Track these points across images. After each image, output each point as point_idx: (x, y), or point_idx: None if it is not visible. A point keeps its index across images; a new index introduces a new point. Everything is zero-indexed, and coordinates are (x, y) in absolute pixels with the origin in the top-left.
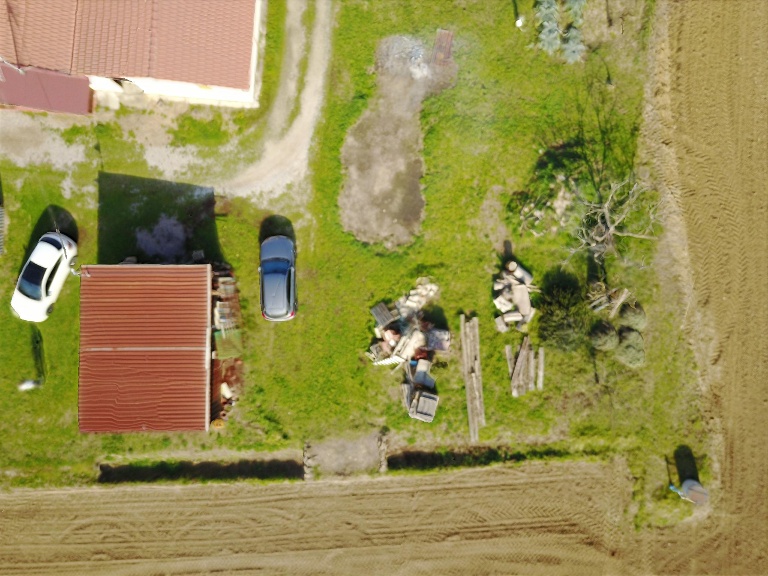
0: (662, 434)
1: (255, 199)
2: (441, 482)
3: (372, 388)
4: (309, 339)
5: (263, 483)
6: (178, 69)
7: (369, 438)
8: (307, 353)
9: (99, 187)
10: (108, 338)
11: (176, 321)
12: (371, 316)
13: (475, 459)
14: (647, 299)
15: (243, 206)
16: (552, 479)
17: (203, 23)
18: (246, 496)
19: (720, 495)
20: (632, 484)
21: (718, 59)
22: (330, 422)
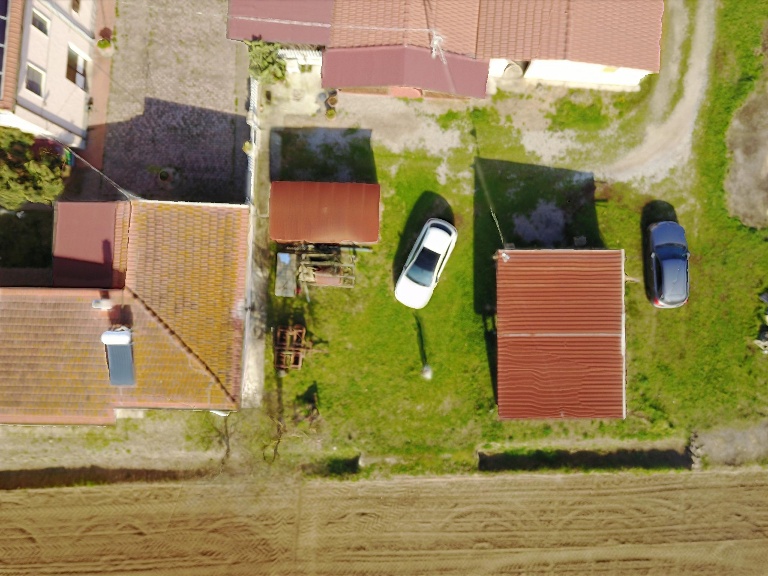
0: None
1: (636, 184)
2: None
3: (761, 377)
4: (694, 327)
5: (648, 473)
6: (592, 51)
7: (759, 428)
8: (692, 341)
9: (475, 173)
10: (526, 324)
11: (592, 307)
12: (762, 303)
13: None
14: None
15: (623, 191)
16: None
17: (616, 4)
18: (629, 486)
19: None
20: None
21: None
22: (717, 411)
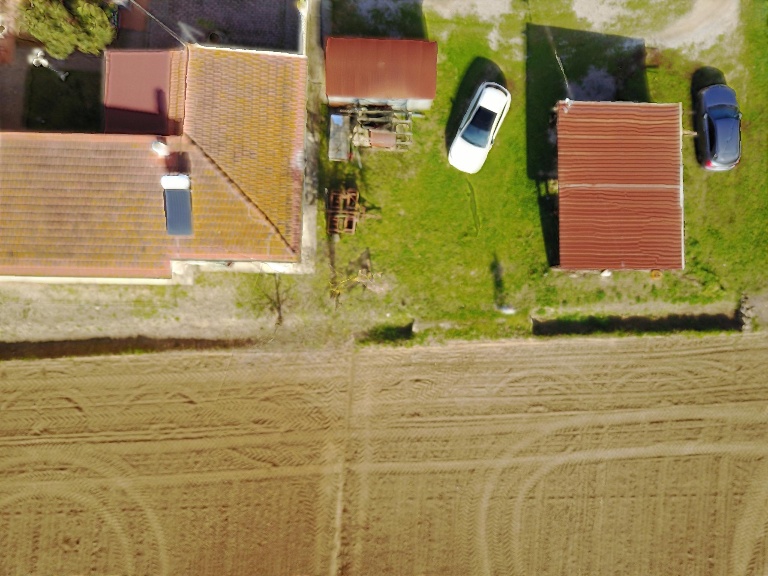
0: None
1: (686, 50)
2: None
3: None
4: (744, 190)
5: (699, 335)
6: None
7: None
8: (741, 205)
9: (527, 39)
10: (587, 174)
11: (651, 158)
12: None
13: None
14: None
15: (674, 58)
16: None
17: None
18: (680, 349)
19: None
20: None
21: None
22: (766, 274)
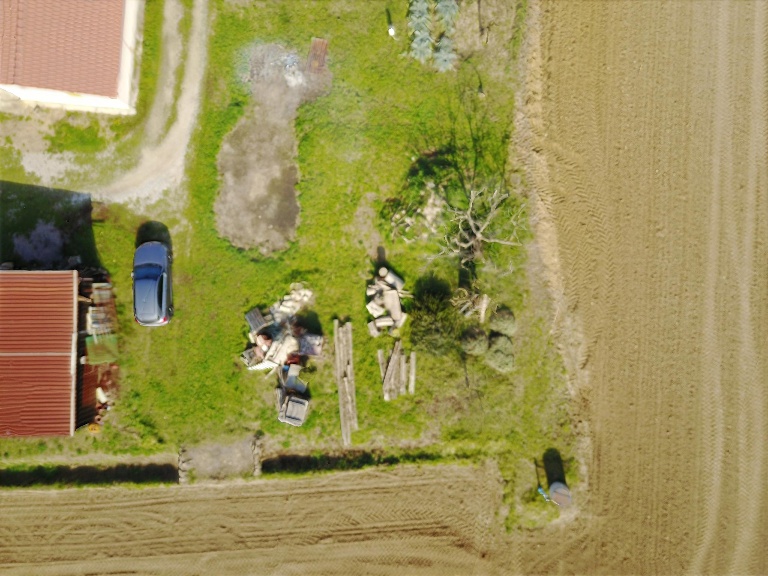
0: (531, 437)
1: (132, 205)
2: (315, 485)
3: (247, 392)
4: (185, 344)
5: (138, 487)
6: (44, 76)
7: (244, 442)
8: (183, 358)
9: None
10: None
11: (41, 327)
12: (245, 321)
13: (349, 462)
14: (517, 304)
15: (120, 212)
16: (425, 482)
17: (70, 31)
18: (122, 500)
19: (587, 497)
20: (502, 487)
21: (586, 68)
22: (205, 426)
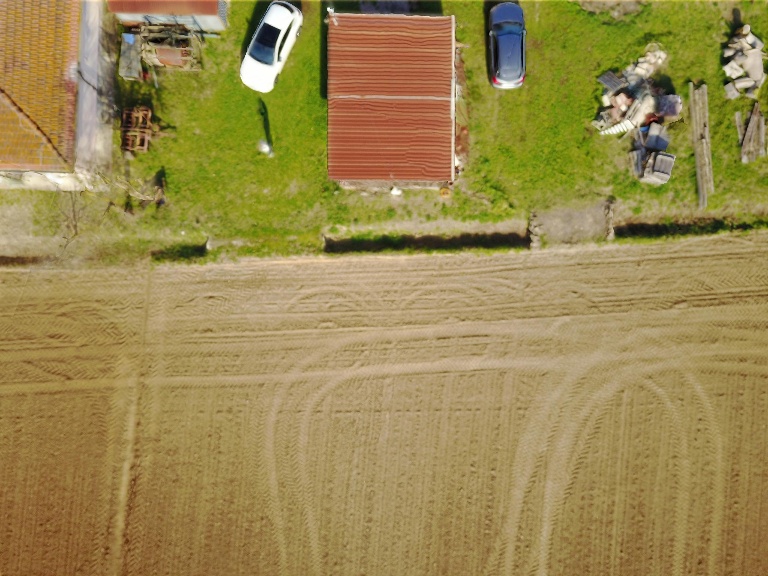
0: None
1: None
2: (667, 251)
3: (598, 158)
4: (534, 110)
5: (488, 253)
6: None
7: (595, 207)
8: (532, 124)
9: None
10: (356, 86)
11: (422, 71)
12: (598, 84)
13: (701, 229)
14: None
15: None
16: None
17: None
18: (470, 267)
19: None
20: None
21: None
22: (555, 192)
